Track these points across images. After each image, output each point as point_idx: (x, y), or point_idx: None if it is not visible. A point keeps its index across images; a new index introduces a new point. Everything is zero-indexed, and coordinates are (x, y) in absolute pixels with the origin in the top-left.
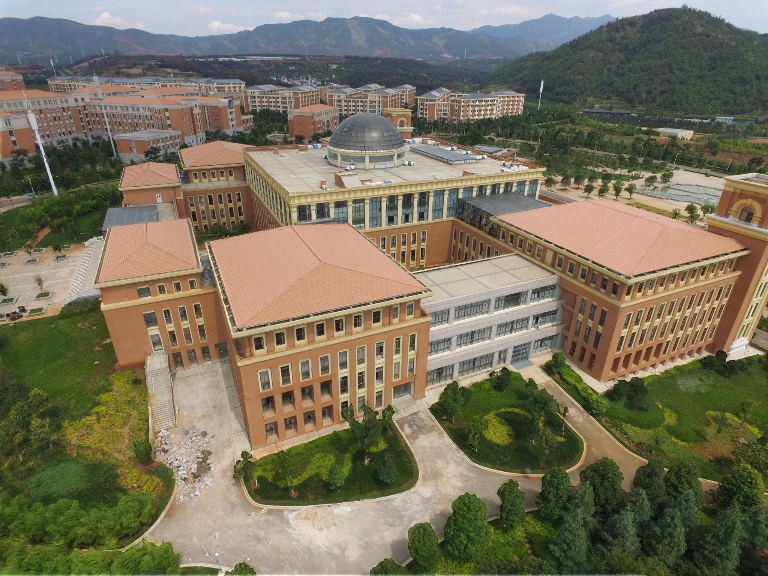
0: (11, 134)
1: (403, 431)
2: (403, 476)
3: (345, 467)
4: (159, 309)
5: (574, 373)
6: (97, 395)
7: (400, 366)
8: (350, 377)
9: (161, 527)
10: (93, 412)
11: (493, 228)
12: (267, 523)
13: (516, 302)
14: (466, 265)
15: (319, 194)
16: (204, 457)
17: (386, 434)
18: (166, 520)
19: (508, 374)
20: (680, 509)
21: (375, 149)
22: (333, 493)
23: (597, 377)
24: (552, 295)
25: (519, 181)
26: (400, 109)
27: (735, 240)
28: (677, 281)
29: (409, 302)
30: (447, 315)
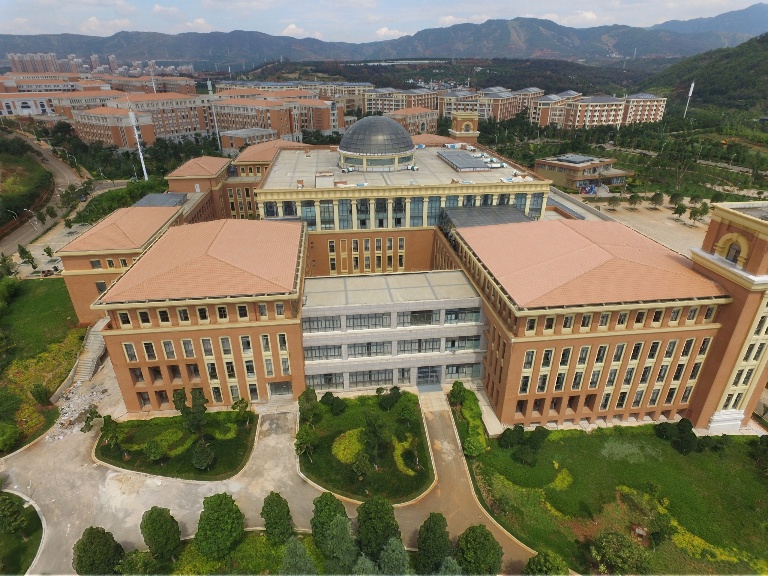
0: (138, 129)
1: (260, 427)
2: (226, 467)
3: (184, 446)
4: (108, 280)
5: (476, 408)
6: (50, 344)
7: (272, 364)
8: (217, 365)
9: (16, 457)
10: (38, 356)
11: (455, 241)
12: (89, 476)
13: (427, 320)
14: (397, 275)
15: (285, 192)
16: (88, 410)
17: (242, 426)
18: (24, 452)
19: (395, 394)
20: (438, 575)
21: (373, 152)
22: (156, 465)
23: (499, 417)
24: (476, 319)
25: (518, 193)
26: (470, 113)
27: (715, 284)
28: (610, 323)
29: (276, 302)
30: (339, 322)
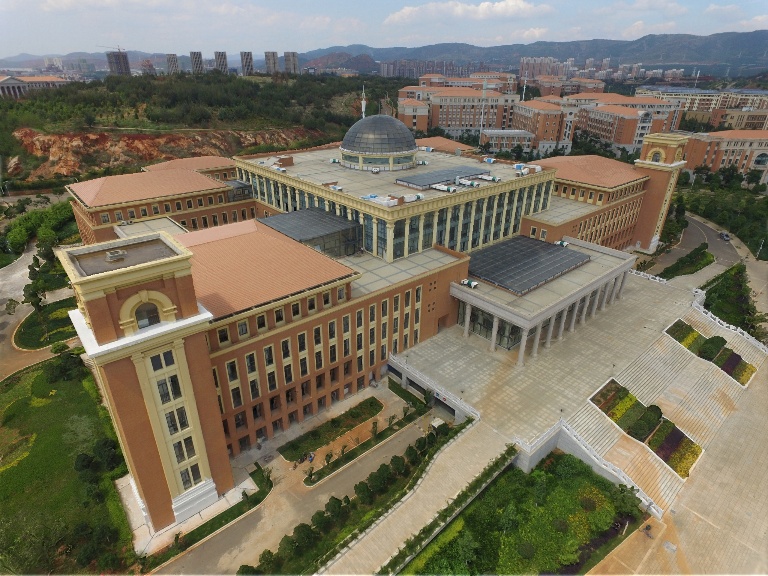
0: (415, 118)
1: None
2: None
3: None
4: None
5: None
6: None
7: None
8: None
9: None
10: None
11: None
12: None
13: None
14: None
15: None
16: None
17: None
18: None
19: None
20: None
21: (346, 147)
22: None
23: None
24: None
25: (367, 214)
26: None
27: None
28: None
29: None
30: None
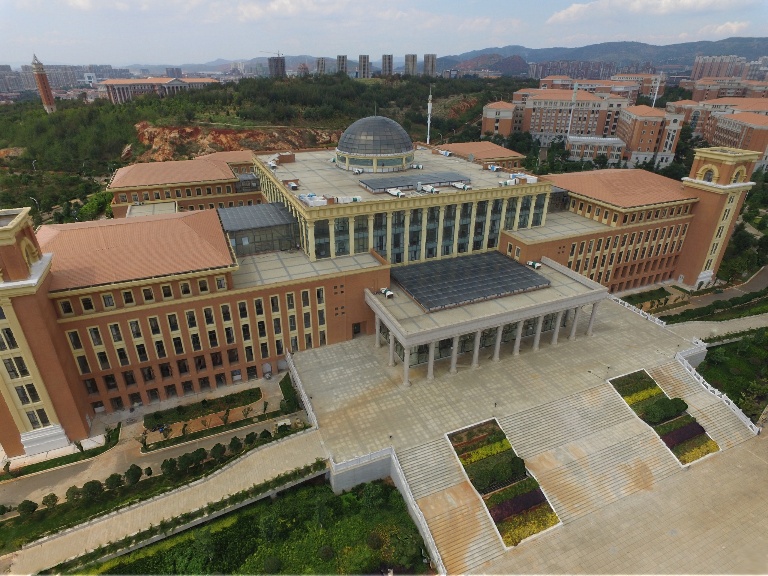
0: (497, 121)
1: None
2: None
3: None
4: None
5: None
6: None
7: None
8: None
9: None
10: None
11: None
12: None
13: None
14: None
15: None
16: None
17: None
18: None
19: None
20: None
21: (338, 147)
22: None
23: None
24: None
25: None
26: None
27: None
28: None
29: None
30: None
